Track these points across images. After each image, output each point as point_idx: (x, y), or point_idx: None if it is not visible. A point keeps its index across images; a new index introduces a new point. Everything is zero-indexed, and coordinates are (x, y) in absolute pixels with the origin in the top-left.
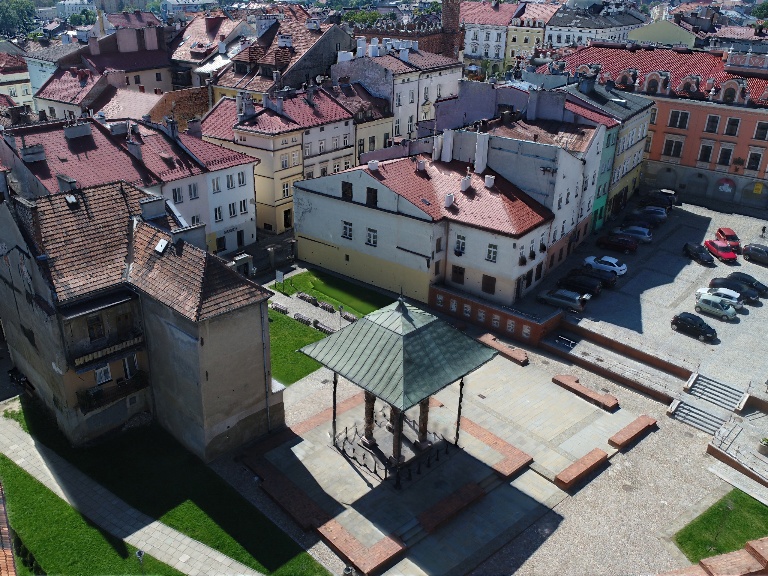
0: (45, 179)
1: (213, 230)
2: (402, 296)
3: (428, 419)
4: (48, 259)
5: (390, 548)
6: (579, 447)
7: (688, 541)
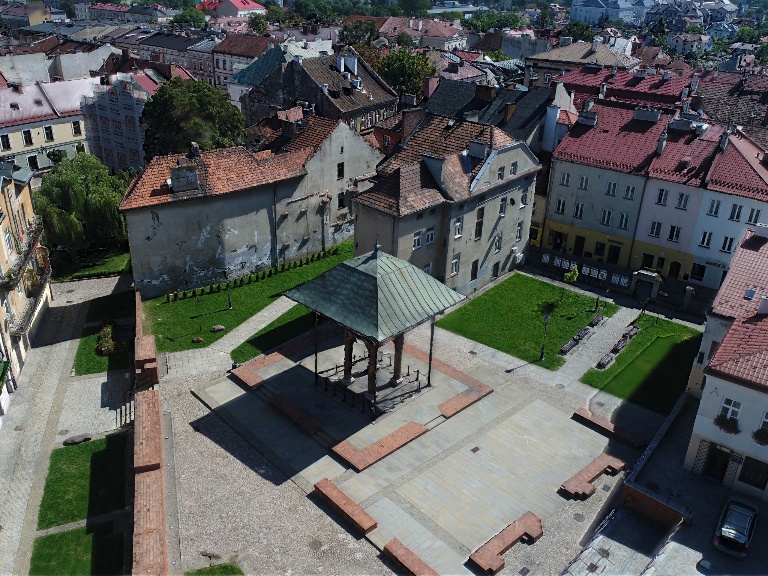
0: (573, 137)
1: (693, 252)
2: (377, 243)
3: (418, 405)
4: (402, 148)
5: (252, 380)
6: (385, 514)
7: (226, 574)
